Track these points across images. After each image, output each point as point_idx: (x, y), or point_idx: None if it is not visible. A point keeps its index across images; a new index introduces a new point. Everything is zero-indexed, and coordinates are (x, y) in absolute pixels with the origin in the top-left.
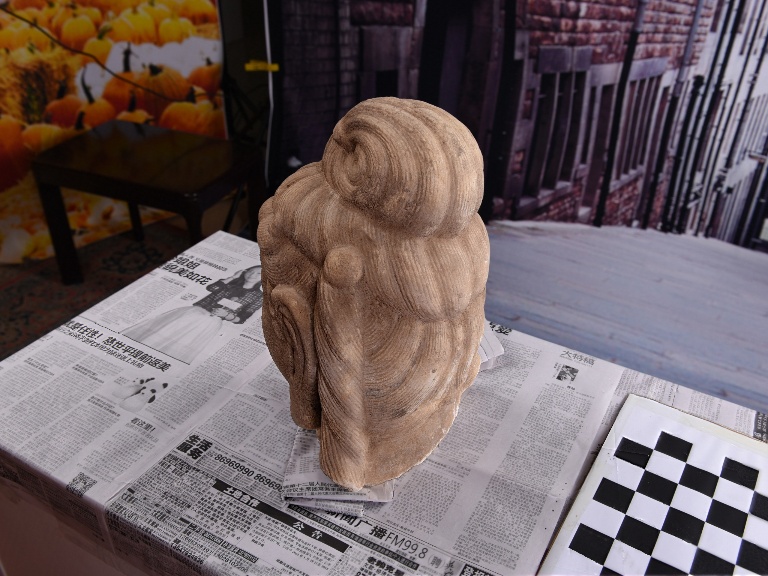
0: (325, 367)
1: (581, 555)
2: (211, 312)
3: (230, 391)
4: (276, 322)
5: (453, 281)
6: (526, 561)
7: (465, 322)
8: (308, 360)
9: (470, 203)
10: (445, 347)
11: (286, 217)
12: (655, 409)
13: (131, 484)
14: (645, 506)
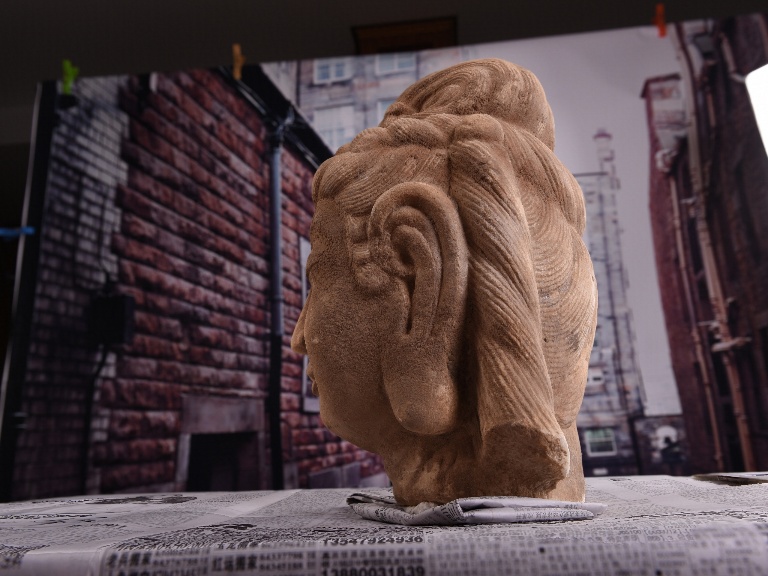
0: (497, 228)
1: None
2: (119, 503)
3: (225, 516)
4: (371, 263)
5: None
6: None
7: None
8: (457, 250)
9: None
10: None
11: (379, 131)
12: None
13: None
14: None
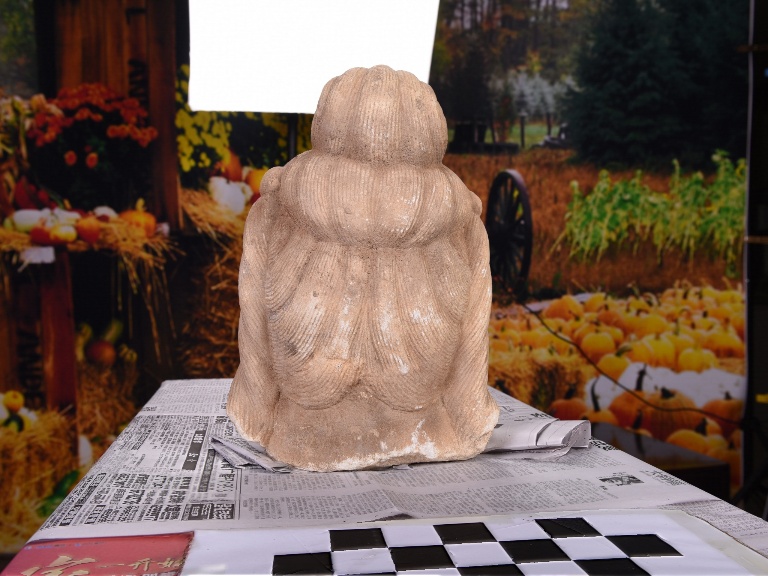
0: None
1: (328, 538)
2: None
3: None
4: None
5: (341, 193)
6: (277, 521)
7: (373, 263)
8: None
9: (378, 124)
10: (332, 271)
11: None
12: (689, 524)
13: (164, 415)
14: (482, 550)
